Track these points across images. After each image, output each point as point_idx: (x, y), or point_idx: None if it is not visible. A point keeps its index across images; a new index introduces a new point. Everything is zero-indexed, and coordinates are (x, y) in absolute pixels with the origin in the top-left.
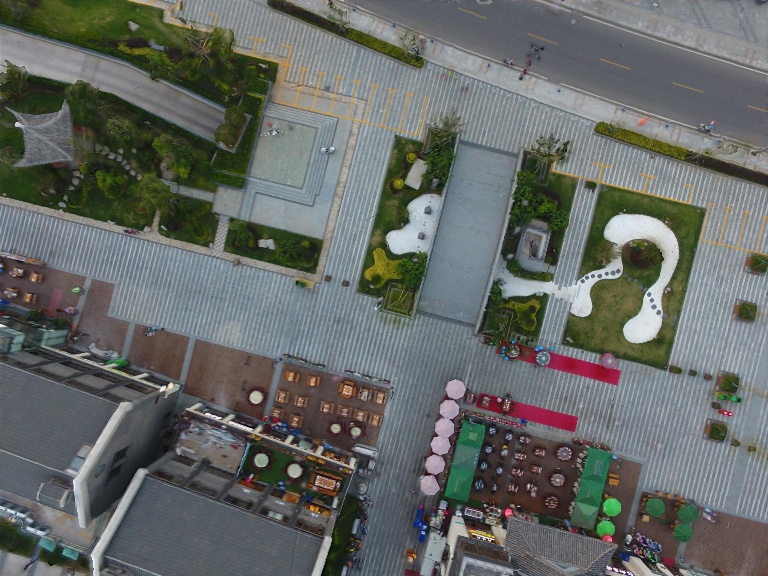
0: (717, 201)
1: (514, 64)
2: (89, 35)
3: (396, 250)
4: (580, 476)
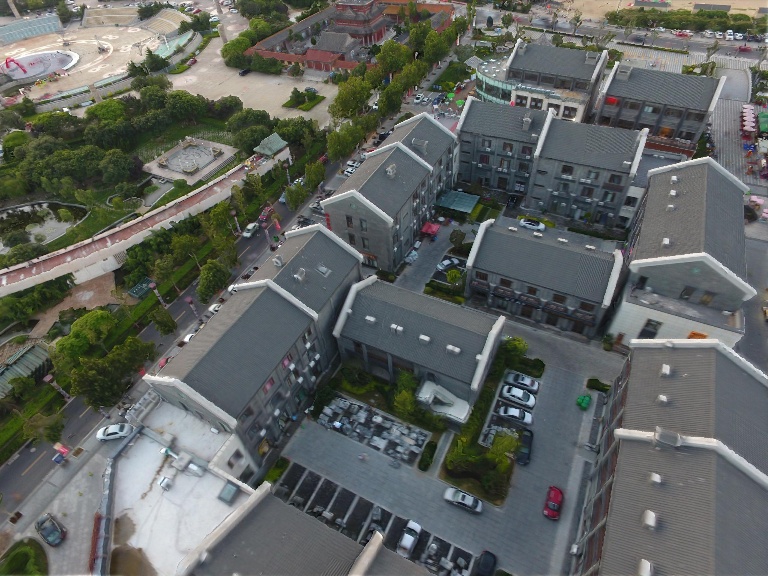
0: None
1: (731, 54)
2: None
3: None
4: None
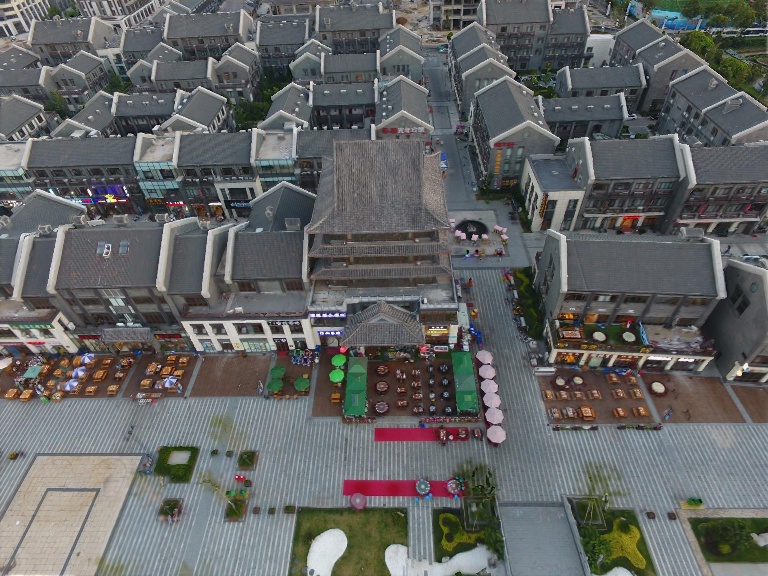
0: None
1: None
2: None
3: (622, 572)
4: None
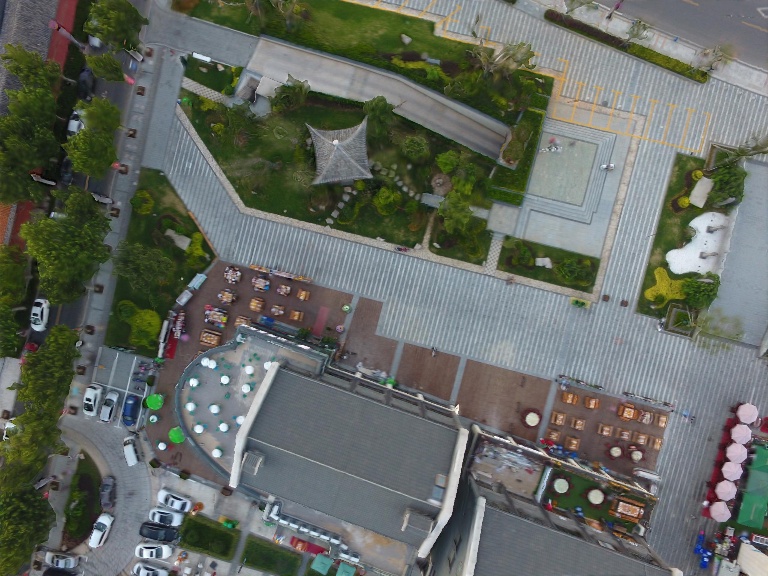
0: None
1: None
2: (362, 48)
3: (676, 269)
4: None
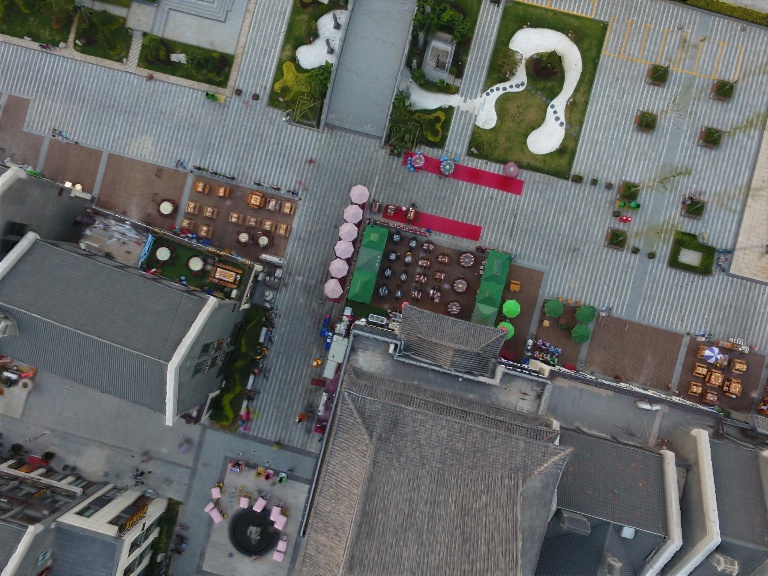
0: (619, 15)
1: None
2: None
3: (306, 65)
4: (481, 280)
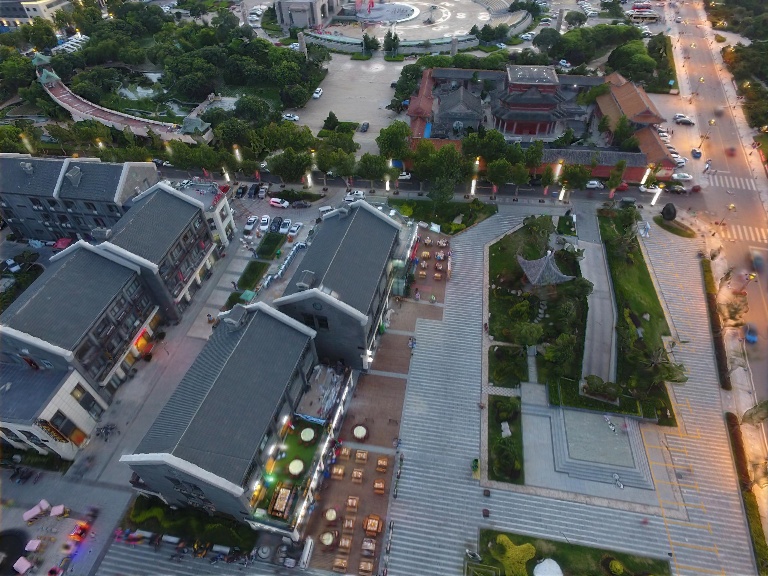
0: None
1: None
2: (625, 292)
3: (538, 573)
4: None
